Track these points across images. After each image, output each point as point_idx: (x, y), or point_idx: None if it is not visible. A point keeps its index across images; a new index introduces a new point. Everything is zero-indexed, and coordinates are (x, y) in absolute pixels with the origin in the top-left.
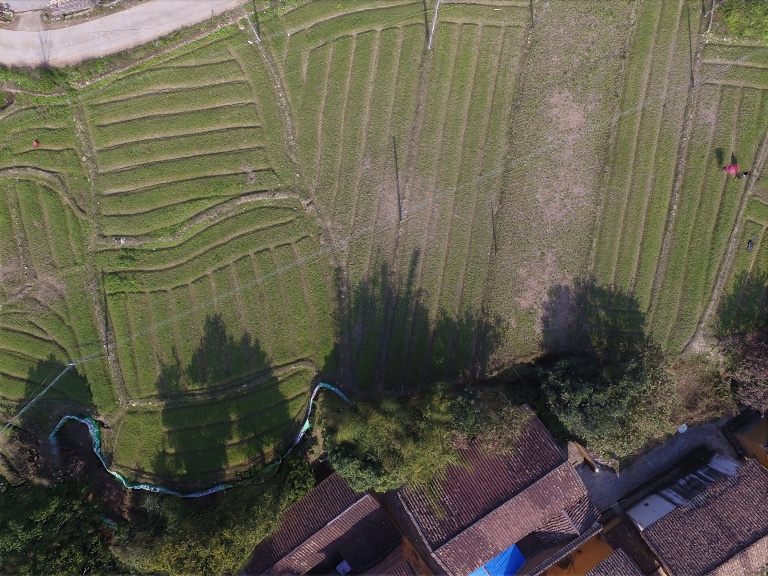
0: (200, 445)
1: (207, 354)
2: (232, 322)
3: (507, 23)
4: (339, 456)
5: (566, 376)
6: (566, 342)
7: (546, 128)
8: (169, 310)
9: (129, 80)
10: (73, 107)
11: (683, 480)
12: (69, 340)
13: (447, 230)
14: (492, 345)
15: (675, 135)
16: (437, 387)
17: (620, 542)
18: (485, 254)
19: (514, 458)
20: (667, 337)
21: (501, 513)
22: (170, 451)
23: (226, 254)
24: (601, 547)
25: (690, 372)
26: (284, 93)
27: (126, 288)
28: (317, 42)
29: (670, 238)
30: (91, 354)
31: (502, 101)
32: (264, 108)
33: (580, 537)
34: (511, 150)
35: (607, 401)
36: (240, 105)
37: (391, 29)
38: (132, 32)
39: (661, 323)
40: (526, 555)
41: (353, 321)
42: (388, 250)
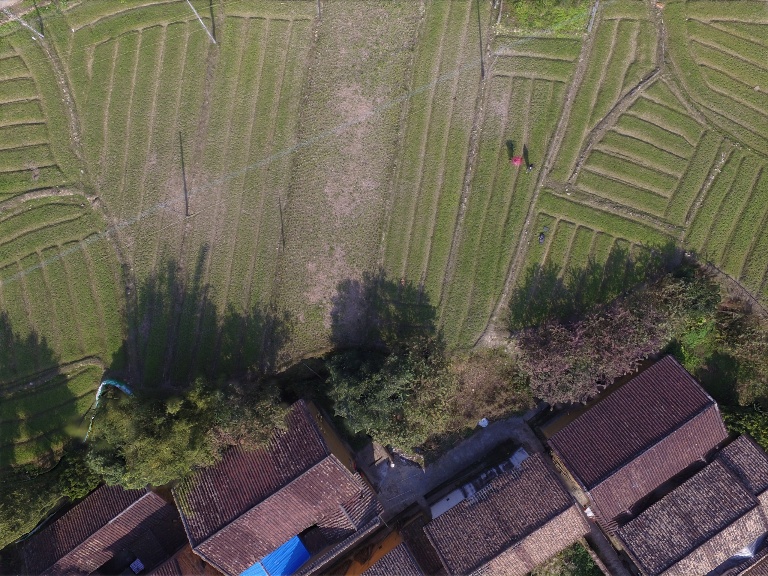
0: None
1: None
2: (18, 320)
3: (294, 17)
4: (91, 453)
5: (338, 371)
6: (356, 337)
7: (334, 122)
8: None
9: None
10: None
11: (485, 474)
12: None
13: (235, 225)
14: (281, 341)
15: (465, 128)
16: (195, 383)
17: (415, 537)
18: (273, 249)
19: (282, 454)
20: (459, 331)
21: (266, 509)
22: None
23: (12, 252)
24: (395, 542)
25: (489, 366)
26: (68, 89)
27: None
28: (102, 37)
29: (461, 231)
30: None
31: (289, 95)
32: (48, 104)
33: (357, 532)
34: (299, 144)
35: (364, 395)
36: (24, 102)
37: (176, 24)
38: None
39: (452, 317)
40: (312, 551)
41: (139, 318)
42: (174, 246)
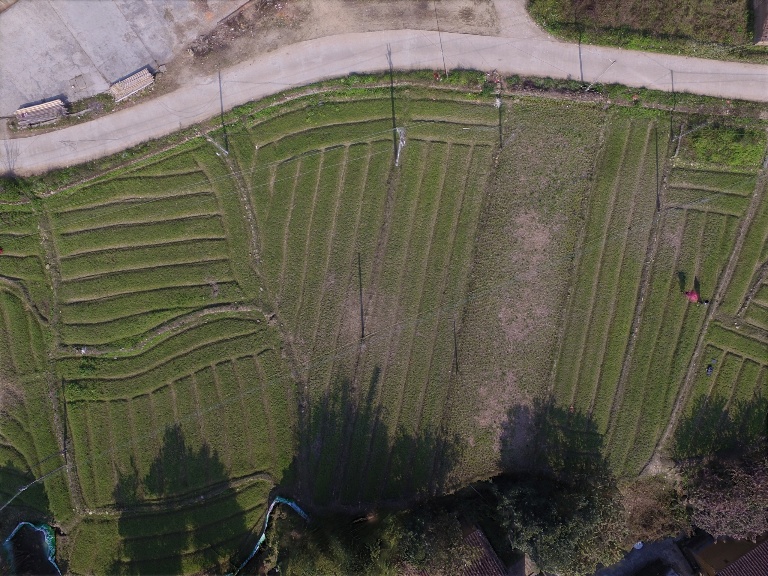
0: (156, 555)
1: (165, 465)
2: (191, 433)
3: (475, 142)
4: None
5: (520, 505)
6: (524, 462)
7: (511, 248)
8: (129, 419)
9: (95, 189)
10: (38, 214)
11: None
12: (27, 447)
13: (409, 347)
14: (450, 463)
15: (639, 258)
16: (389, 520)
17: None
18: (446, 372)
19: None
20: (624, 459)
21: None
22: (126, 560)
23: (187, 365)
24: None
25: (647, 490)
26: (250, 206)
27: (86, 397)
28: (285, 156)
29: (631, 361)
30: (49, 461)
31: (468, 220)
32: (230, 221)
33: None
34: (475, 269)
35: (557, 540)
36: (206, 217)
37: (359, 145)
38: (99, 143)
39: (619, 445)
40: None
41: (312, 436)
42: (349, 366)
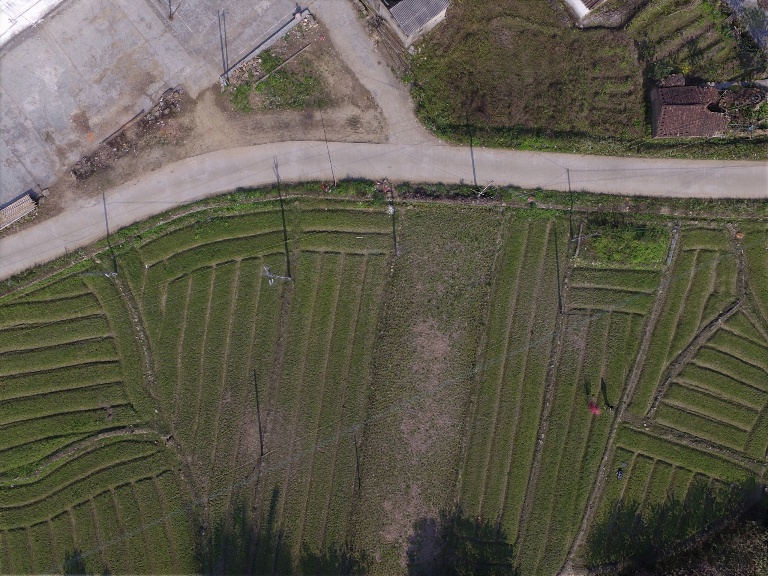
0: None
1: None
2: (92, 559)
3: (370, 251)
4: None
5: None
6: None
7: (410, 358)
8: (28, 548)
9: None
10: None
11: None
12: None
13: (310, 463)
14: None
15: (543, 362)
16: None
17: None
18: (349, 488)
19: None
20: (536, 568)
21: None
22: None
23: (85, 490)
24: None
25: None
26: (142, 327)
27: None
28: (175, 274)
29: (538, 467)
30: None
31: (365, 331)
32: (121, 343)
33: None
34: (375, 381)
35: None
36: (97, 340)
37: (250, 260)
38: None
39: (529, 555)
40: None
41: (214, 559)
42: (249, 485)
